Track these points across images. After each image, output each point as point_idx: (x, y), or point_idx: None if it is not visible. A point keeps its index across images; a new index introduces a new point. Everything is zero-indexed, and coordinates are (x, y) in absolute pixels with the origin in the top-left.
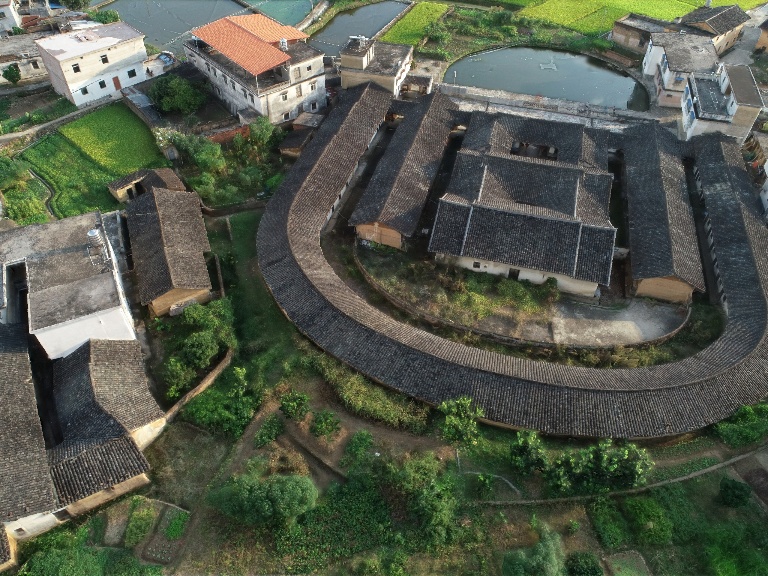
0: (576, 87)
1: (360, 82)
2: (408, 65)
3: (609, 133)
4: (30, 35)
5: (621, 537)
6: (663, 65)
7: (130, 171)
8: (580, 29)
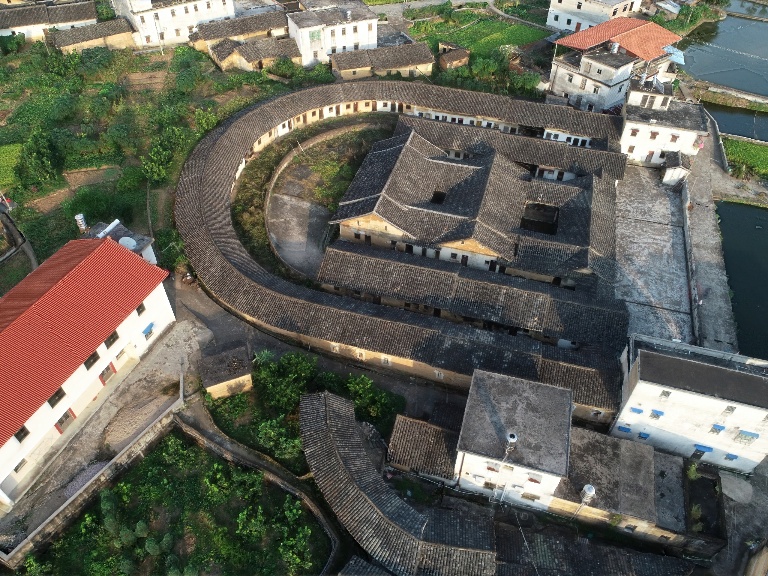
0: None
1: None
2: (690, 146)
3: None
4: None
5: (126, 173)
6: None
7: (472, 50)
8: None
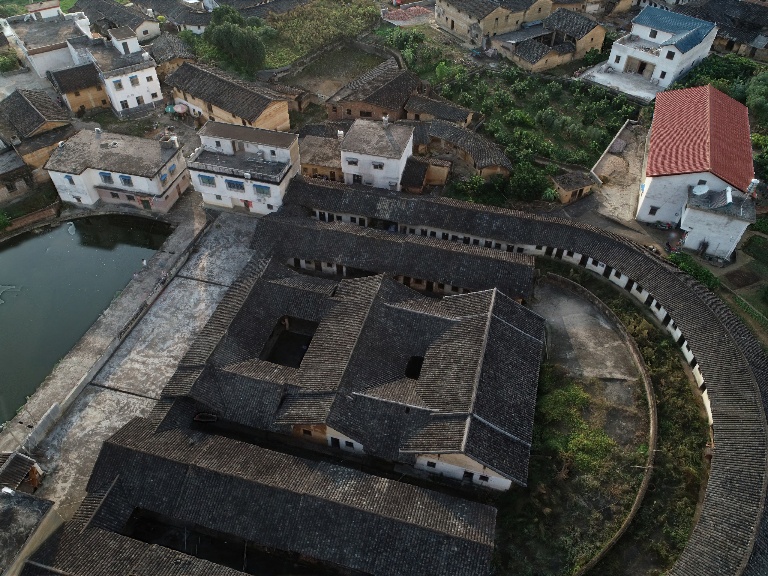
0: (81, 276)
1: None
2: None
3: None
4: None
5: None
6: (119, 181)
7: None
8: None
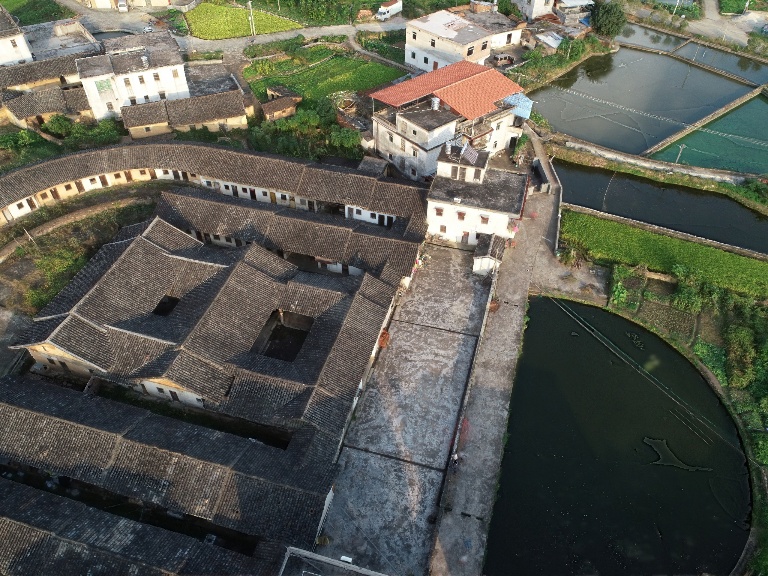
0: (575, 480)
1: None
2: (505, 229)
3: None
4: (506, 20)
5: None
6: None
7: (307, 95)
8: None
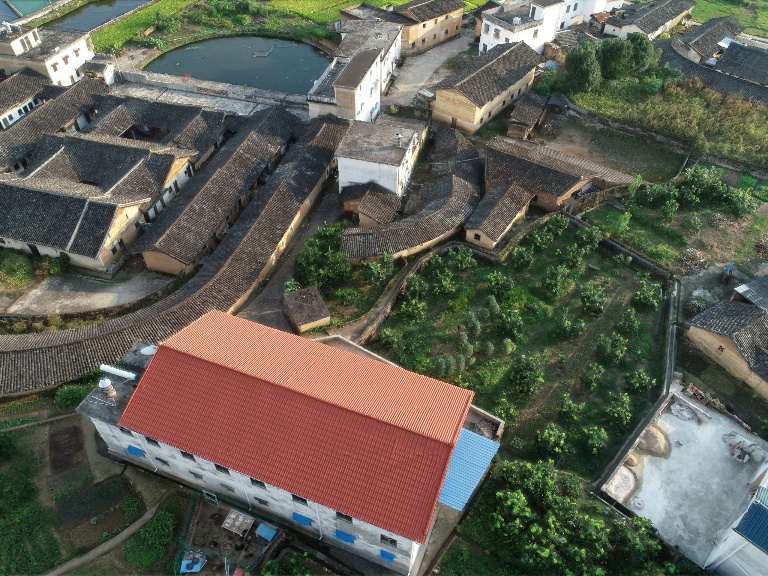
0: (271, 74)
1: (19, 68)
2: (87, 52)
3: (230, 116)
4: None
5: None
6: None
7: None
8: (317, 18)
